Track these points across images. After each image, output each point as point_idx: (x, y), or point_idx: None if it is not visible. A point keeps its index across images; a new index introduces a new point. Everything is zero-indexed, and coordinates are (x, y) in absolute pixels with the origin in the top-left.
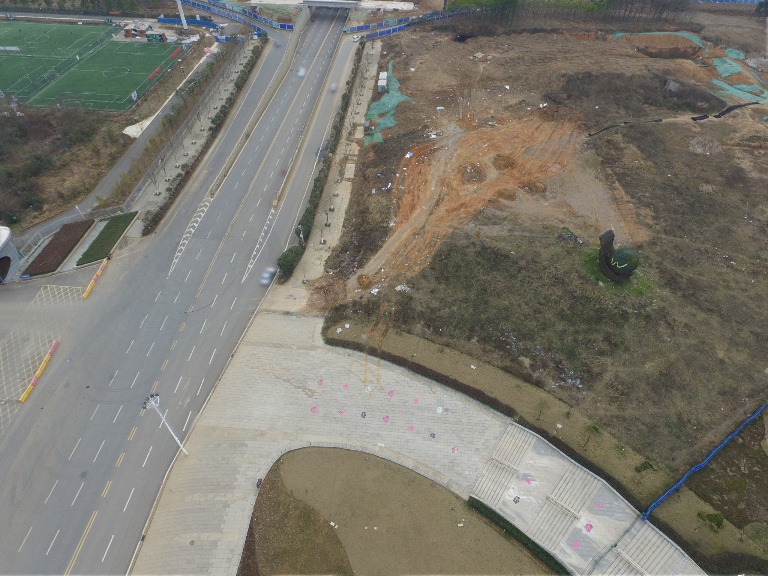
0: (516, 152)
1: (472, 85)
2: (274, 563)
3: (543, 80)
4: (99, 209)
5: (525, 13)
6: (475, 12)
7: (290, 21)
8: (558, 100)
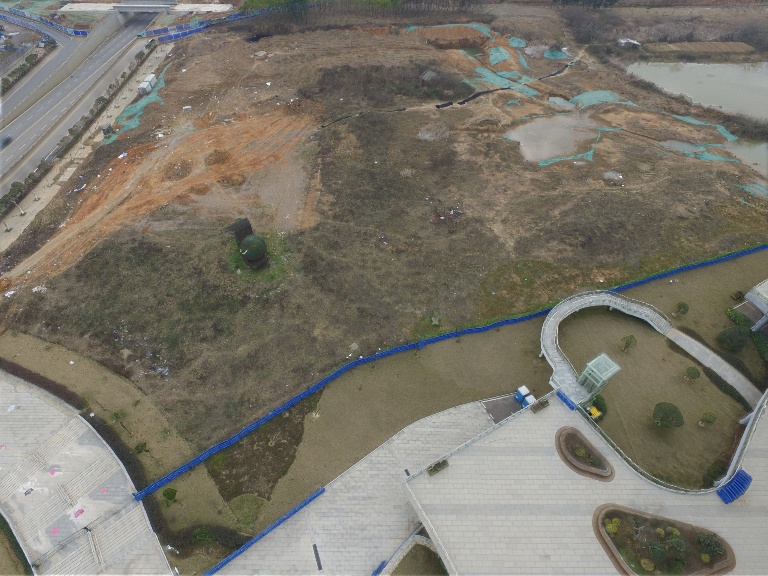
0: (236, 147)
1: (234, 83)
2: None
3: (303, 75)
4: None
5: (324, 11)
6: (269, 11)
7: (88, 27)
8: (308, 94)
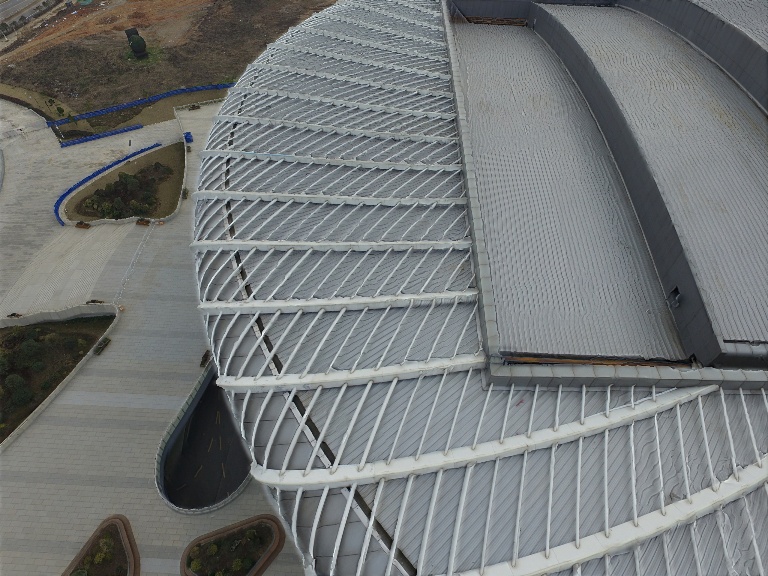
0: (151, 11)
1: None
2: None
3: None
4: None
5: None
6: None
7: None
8: None
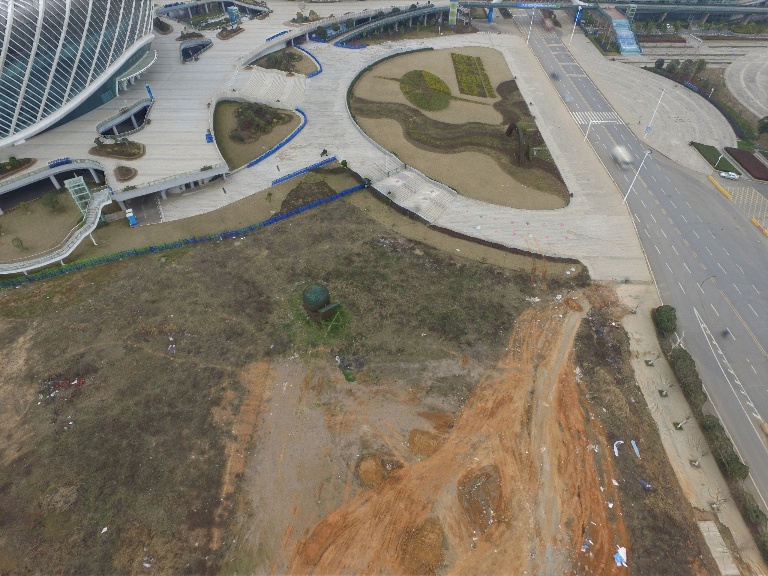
0: None
1: None
2: (546, 176)
3: None
4: None
5: None
6: None
7: None
8: None
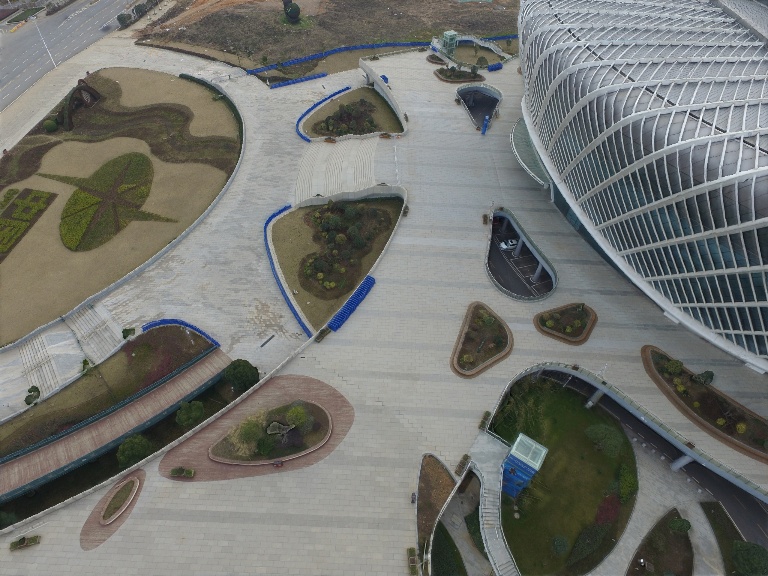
0: None
1: None
2: None
3: None
4: (22, 6)
5: None
6: None
7: None
8: None
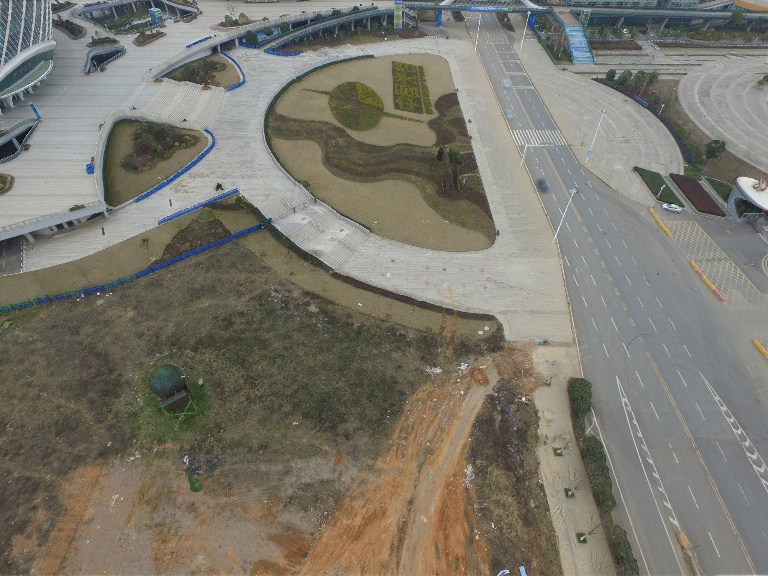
0: None
1: None
2: (473, 209)
3: None
4: None
5: None
6: None
7: None
8: None
